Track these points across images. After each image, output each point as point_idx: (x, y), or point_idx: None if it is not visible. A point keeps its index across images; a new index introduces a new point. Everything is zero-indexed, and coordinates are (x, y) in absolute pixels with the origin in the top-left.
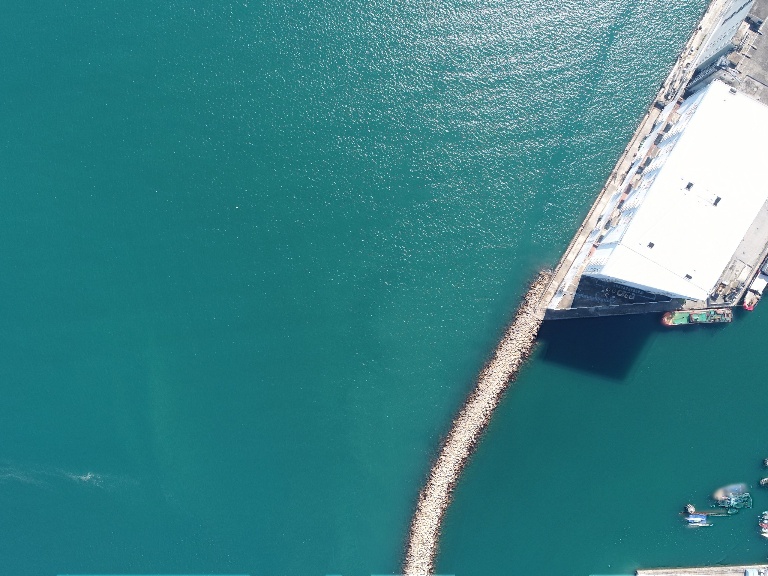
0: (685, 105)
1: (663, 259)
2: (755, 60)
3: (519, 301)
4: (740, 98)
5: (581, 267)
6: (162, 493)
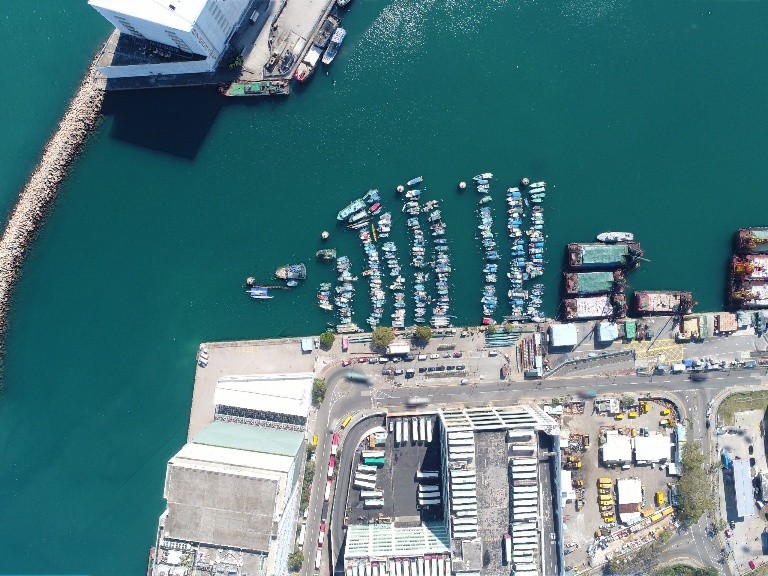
0: None
1: None
2: None
3: (84, 73)
4: None
5: None
6: None
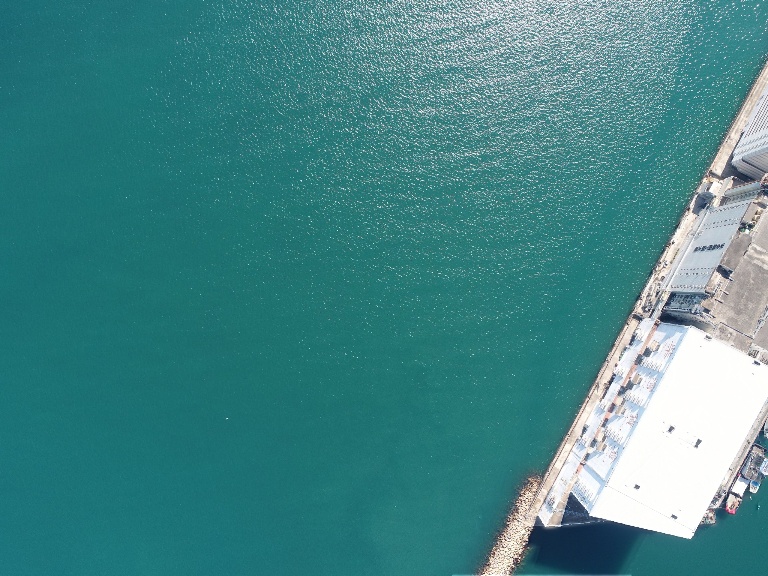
0: (663, 332)
1: (649, 499)
2: (727, 305)
3: (509, 507)
4: (715, 344)
5: (569, 484)
6: None
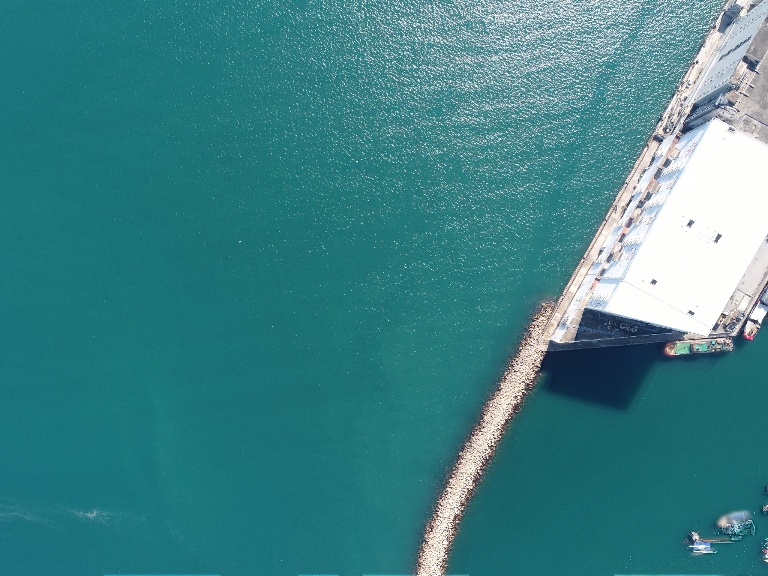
0: (684, 140)
1: (666, 295)
2: (753, 98)
3: (522, 333)
4: (739, 136)
5: (584, 300)
6: (168, 529)
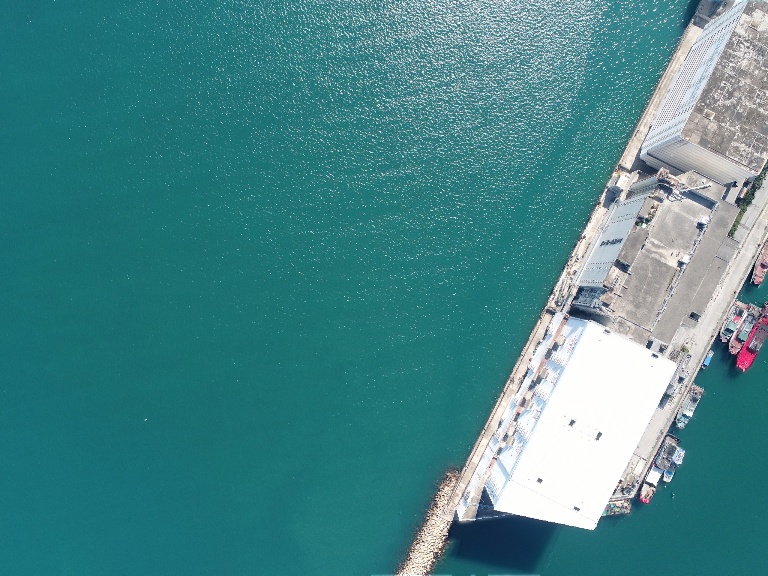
0: (569, 327)
1: (552, 492)
2: (627, 299)
3: (429, 502)
4: (614, 338)
5: (483, 479)
6: None
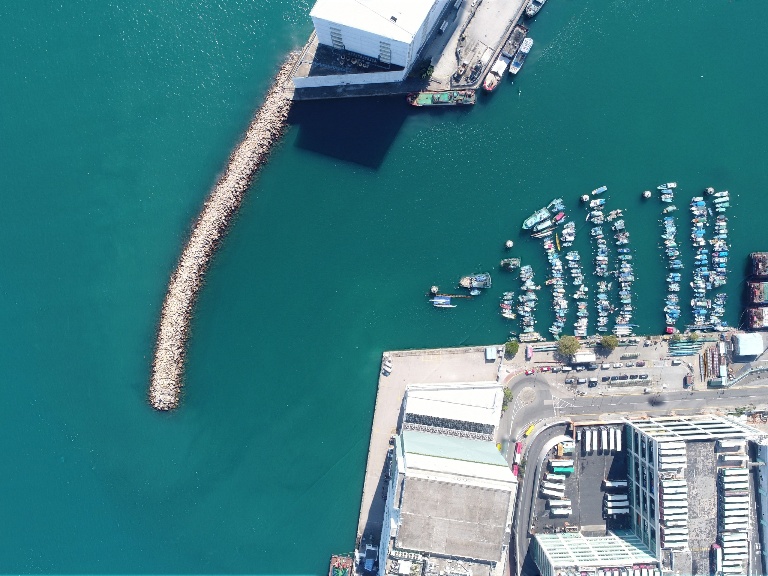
0: None
1: (370, 2)
2: None
3: (270, 82)
4: None
5: None
6: None
